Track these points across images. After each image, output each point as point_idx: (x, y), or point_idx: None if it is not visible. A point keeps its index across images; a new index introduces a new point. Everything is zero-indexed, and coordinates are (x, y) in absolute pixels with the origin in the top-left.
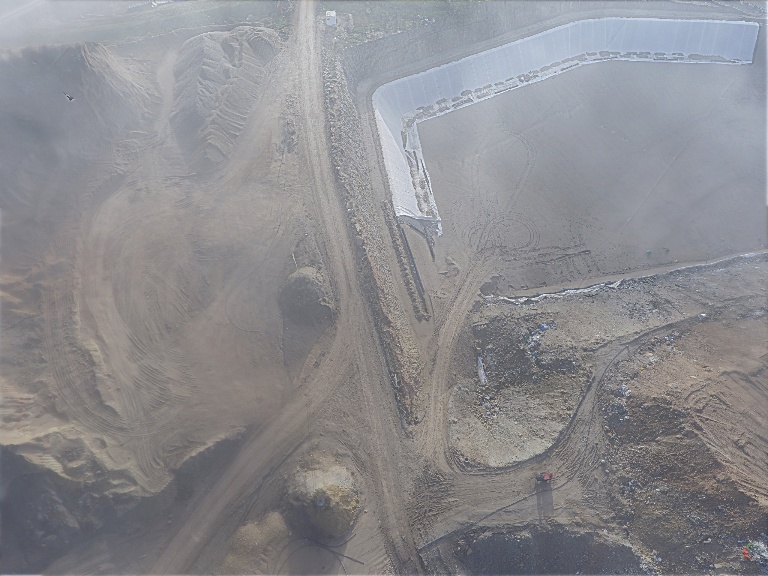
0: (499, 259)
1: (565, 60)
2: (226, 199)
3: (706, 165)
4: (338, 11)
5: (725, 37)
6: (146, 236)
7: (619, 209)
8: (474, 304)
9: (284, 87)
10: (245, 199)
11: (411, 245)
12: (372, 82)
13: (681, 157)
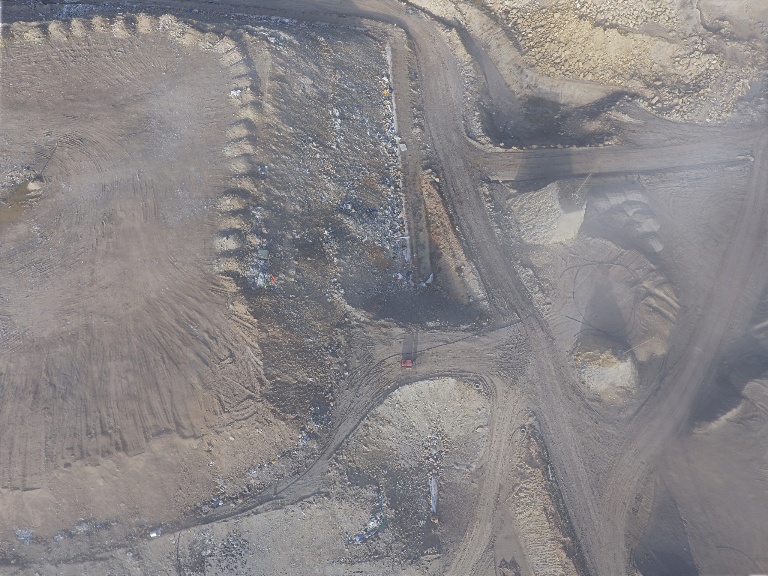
0: None
1: None
2: None
3: None
4: None
5: None
6: None
7: None
8: None
9: None
10: None
11: None
12: None
13: None
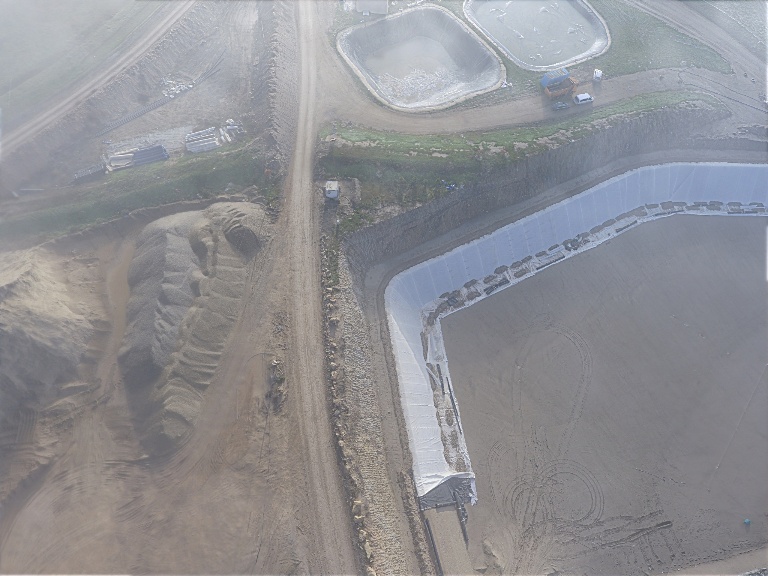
0: (553, 541)
1: (620, 216)
2: (188, 500)
3: None
4: (341, 174)
5: None
6: (73, 575)
7: (703, 450)
8: None
9: (271, 300)
10: (214, 500)
11: (439, 548)
12: (384, 270)
13: None
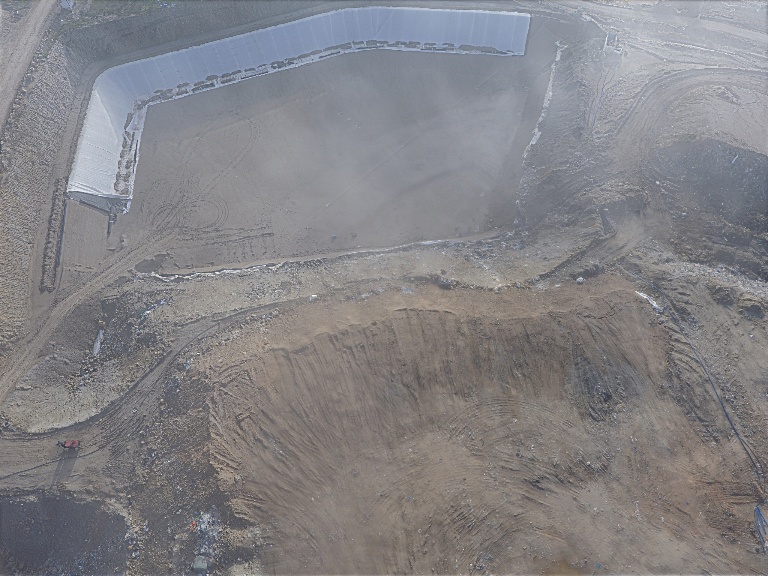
0: (175, 238)
1: (327, 48)
2: None
3: (432, 154)
4: None
5: (496, 28)
6: None
7: (322, 194)
8: (117, 279)
9: None
10: None
11: (67, 220)
12: (103, 64)
13: (409, 145)
